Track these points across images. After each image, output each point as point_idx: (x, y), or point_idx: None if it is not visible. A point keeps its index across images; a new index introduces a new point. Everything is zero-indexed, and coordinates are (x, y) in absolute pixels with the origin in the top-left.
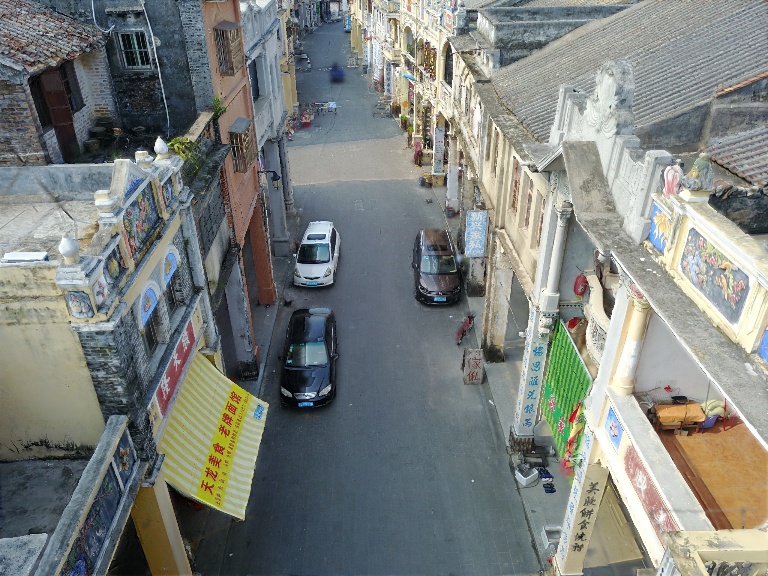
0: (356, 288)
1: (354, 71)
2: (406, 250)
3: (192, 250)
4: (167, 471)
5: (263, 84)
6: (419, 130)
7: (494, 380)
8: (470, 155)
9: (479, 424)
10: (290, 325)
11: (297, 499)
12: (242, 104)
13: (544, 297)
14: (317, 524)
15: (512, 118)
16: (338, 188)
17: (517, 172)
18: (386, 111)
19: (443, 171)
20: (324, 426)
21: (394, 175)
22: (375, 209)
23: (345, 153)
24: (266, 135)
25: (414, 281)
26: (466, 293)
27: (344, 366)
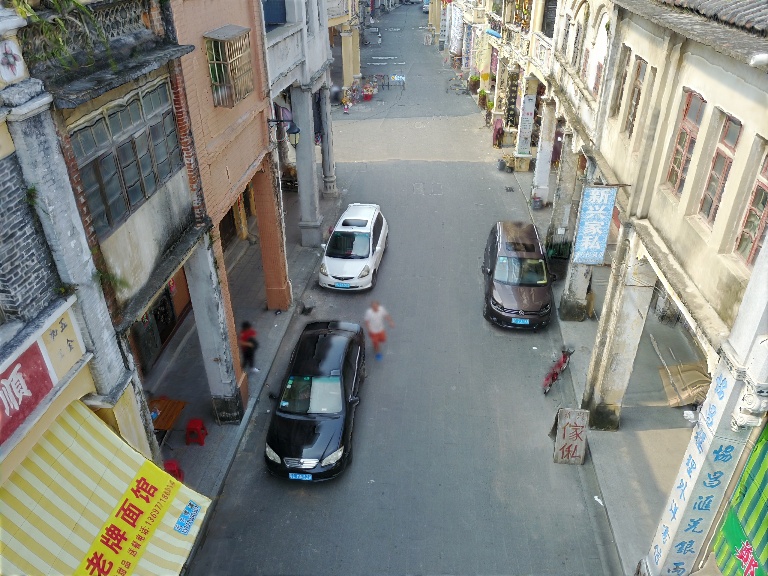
0: (402, 296)
1: (429, 48)
2: (475, 249)
3: (46, 210)
4: None
5: (292, 5)
6: (501, 105)
7: (603, 461)
8: (579, 116)
9: (579, 541)
10: (297, 345)
11: None
12: (243, 11)
13: (767, 356)
14: None
15: (688, 16)
16: (395, 168)
17: (687, 117)
18: (462, 88)
19: (529, 152)
20: (325, 516)
21: (466, 156)
22: (438, 195)
23: (409, 129)
24: (292, 77)
25: (483, 292)
26: (557, 314)
27: (370, 413)
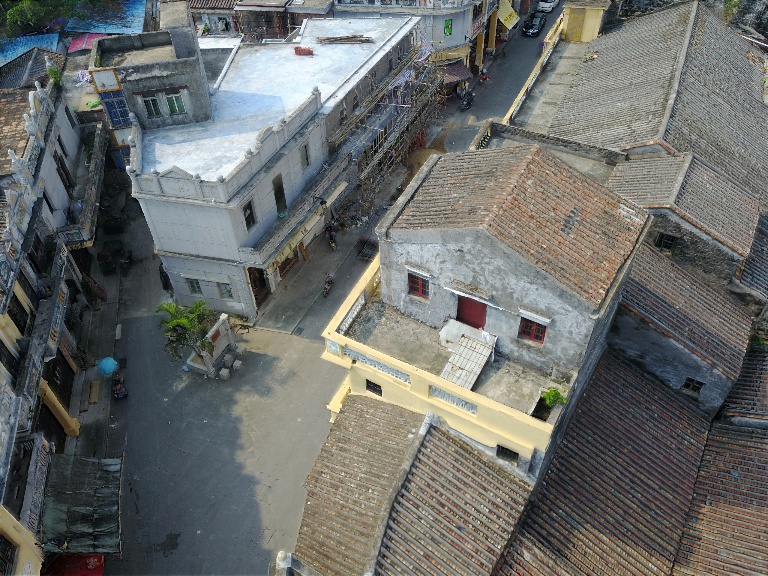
0: None
1: None
2: None
3: None
4: (498, 14)
5: None
6: None
7: None
8: None
9: None
10: None
11: (520, 49)
12: None
13: None
14: (523, 53)
15: None
16: None
17: None
18: None
19: None
20: (532, 40)
21: None
22: None
23: None
24: None
25: None
26: None
27: (544, 31)
